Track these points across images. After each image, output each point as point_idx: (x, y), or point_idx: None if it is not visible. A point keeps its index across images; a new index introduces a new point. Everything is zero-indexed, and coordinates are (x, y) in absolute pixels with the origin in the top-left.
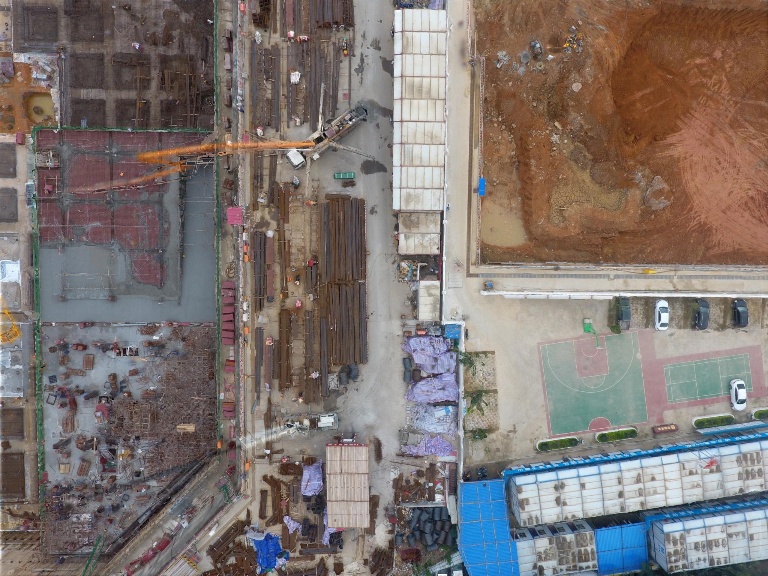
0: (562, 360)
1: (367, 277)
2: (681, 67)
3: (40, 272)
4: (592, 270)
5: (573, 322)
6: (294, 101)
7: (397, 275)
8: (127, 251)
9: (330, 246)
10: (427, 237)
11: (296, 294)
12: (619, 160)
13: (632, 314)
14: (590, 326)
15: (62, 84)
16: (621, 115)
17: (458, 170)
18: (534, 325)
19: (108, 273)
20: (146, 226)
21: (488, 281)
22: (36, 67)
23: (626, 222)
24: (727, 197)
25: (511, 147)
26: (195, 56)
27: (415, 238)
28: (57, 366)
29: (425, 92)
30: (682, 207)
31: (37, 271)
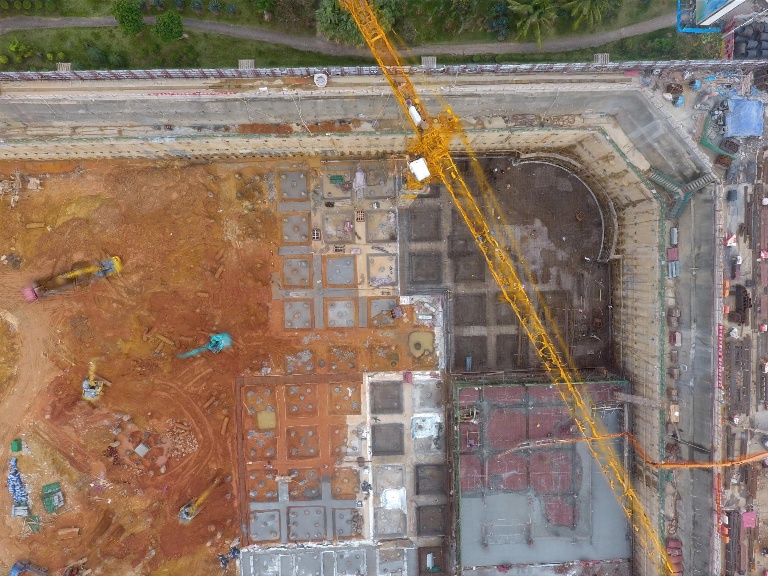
0: None
1: None
2: None
3: None
4: None
5: None
6: None
7: None
8: (542, 496)
9: None
10: None
11: (762, 563)
12: None
13: None
14: None
15: (448, 324)
16: None
17: None
18: None
19: (530, 521)
20: (560, 472)
21: None
22: (418, 307)
23: None
24: None
25: None
26: (571, 291)
27: None
28: None
29: None
30: None
31: (458, 519)
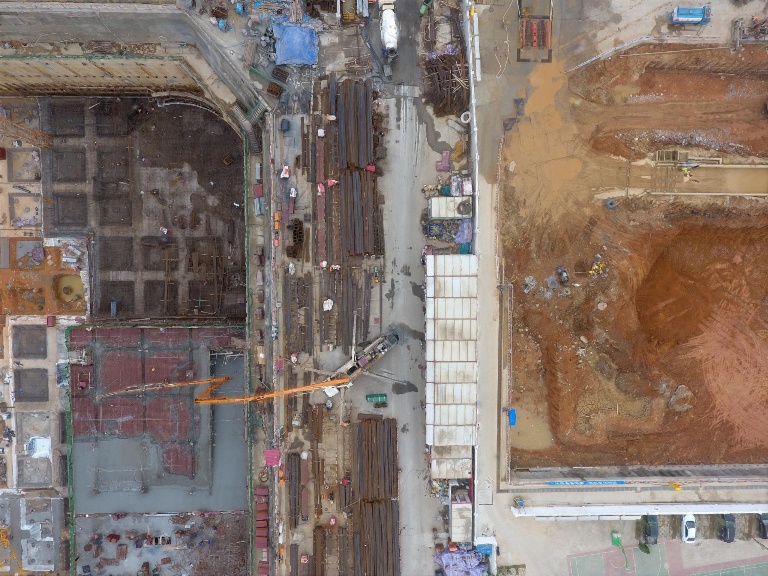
0: (591, 572)
1: (399, 493)
2: (702, 272)
3: (74, 465)
4: (619, 483)
5: (601, 535)
6: (327, 328)
7: (428, 490)
8: (159, 443)
9: (363, 465)
10: (459, 462)
11: (330, 510)
12: (643, 371)
13: (659, 526)
14: (618, 541)
15: (92, 268)
16: (645, 326)
17: (487, 391)
18: (563, 539)
19: (141, 467)
20: (177, 418)
21: (518, 499)
22: (66, 249)
23: (651, 428)
24: (748, 395)
25: (537, 355)
26: (222, 237)
27: (447, 463)
28: (91, 556)
29: (457, 334)
30: (705, 406)
31: (71, 464)
